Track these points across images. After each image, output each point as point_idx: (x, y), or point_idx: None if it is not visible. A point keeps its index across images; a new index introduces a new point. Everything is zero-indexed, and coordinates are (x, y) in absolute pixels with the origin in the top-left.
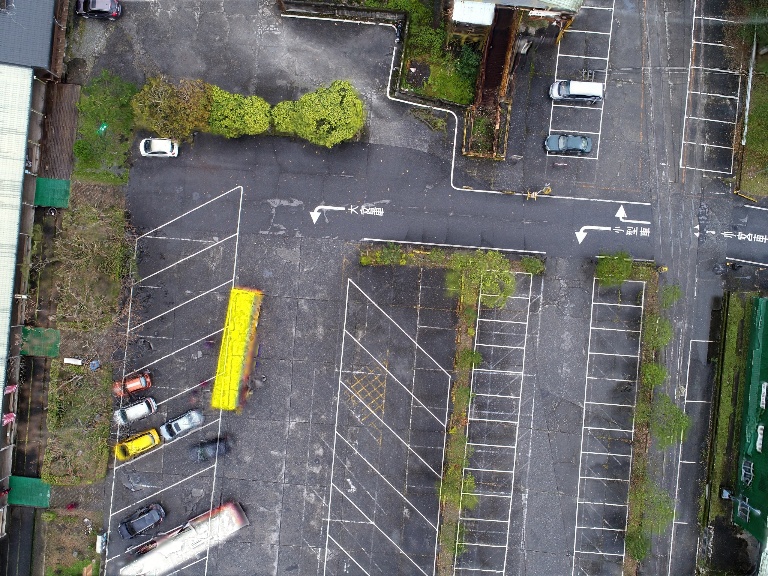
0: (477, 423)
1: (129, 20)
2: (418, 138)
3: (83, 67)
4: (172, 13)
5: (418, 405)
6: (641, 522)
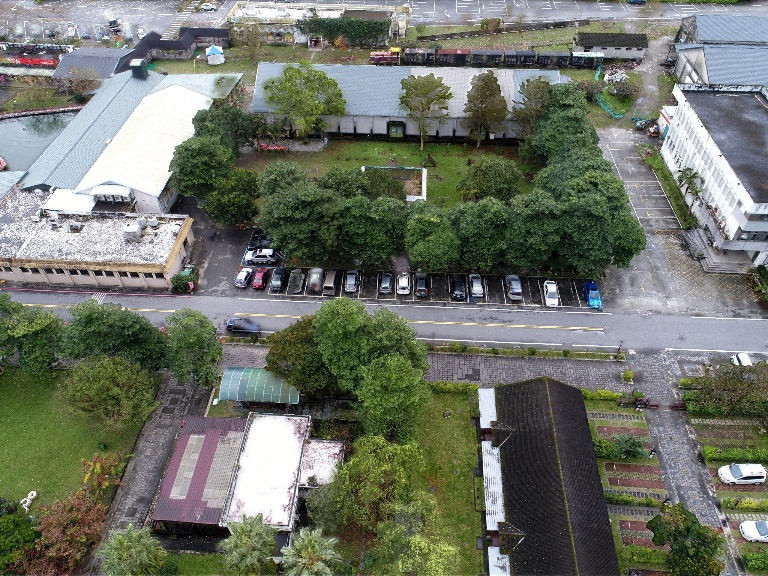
0: None
1: None
2: None
3: None
4: None
5: None
6: None
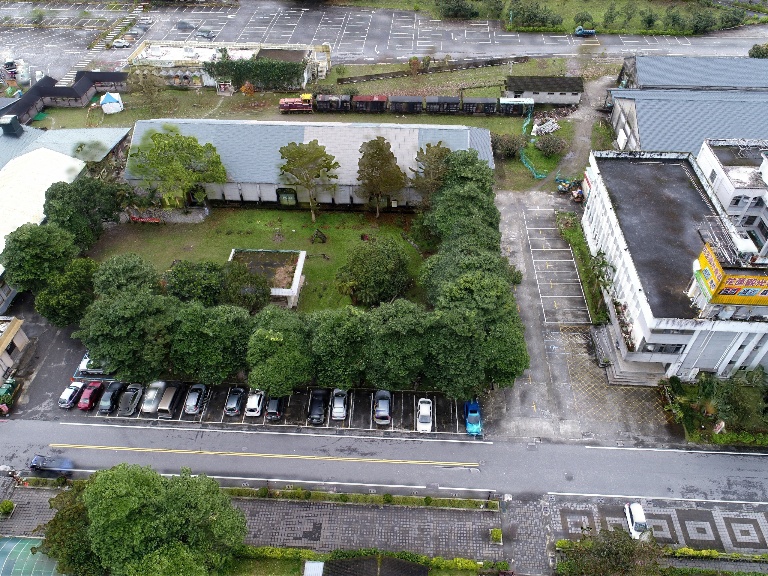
0: (24, 23)
1: None
2: None
3: None
4: None
5: (7, 31)
6: (83, 2)
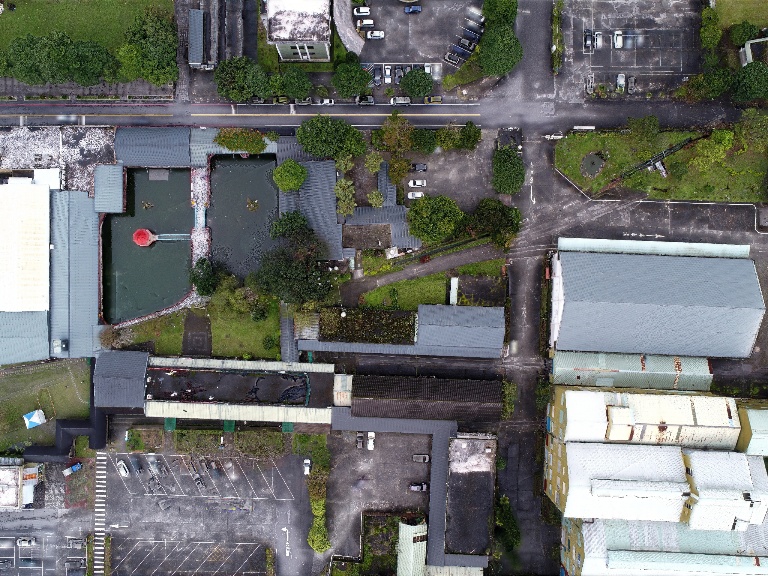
0: None
1: (357, 451)
2: (317, 568)
3: (338, 434)
4: (361, 468)
5: (212, 574)
6: None
